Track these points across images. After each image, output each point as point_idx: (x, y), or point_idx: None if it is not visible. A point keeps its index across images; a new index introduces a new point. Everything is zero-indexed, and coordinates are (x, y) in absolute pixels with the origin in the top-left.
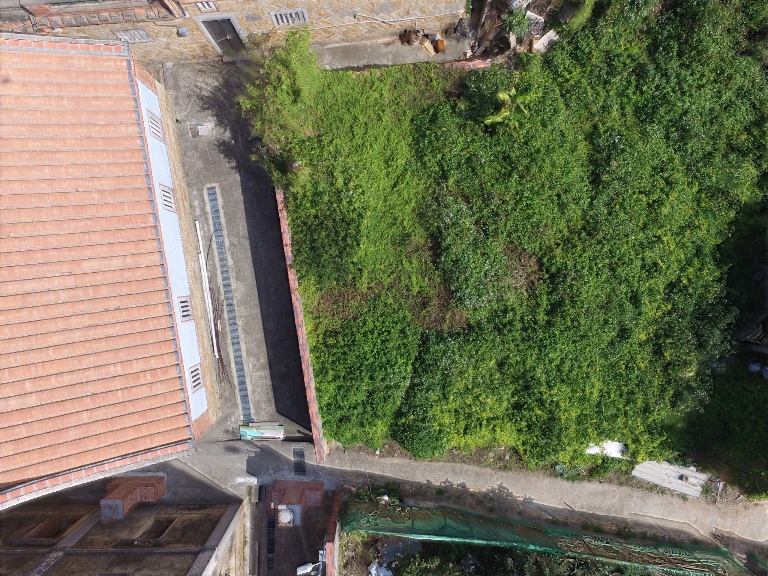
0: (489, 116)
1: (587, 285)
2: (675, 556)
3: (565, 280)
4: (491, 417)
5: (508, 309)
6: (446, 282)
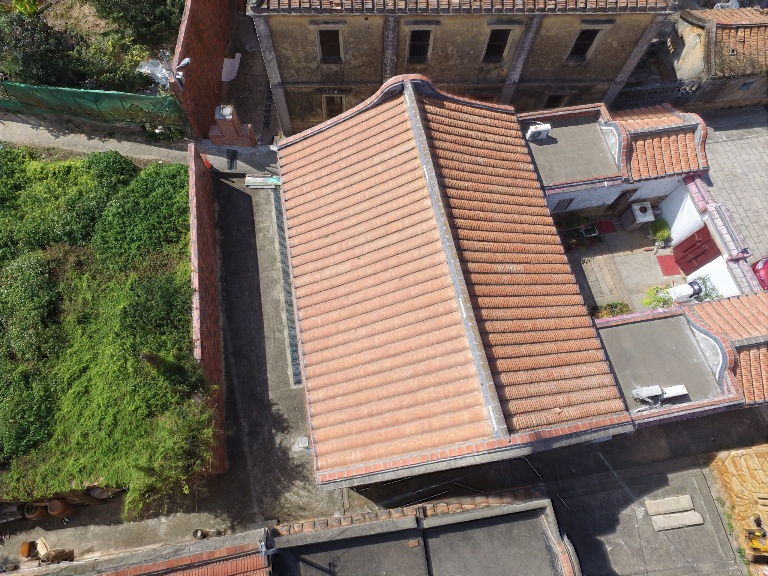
0: None
1: None
2: None
3: None
4: None
5: None
6: (53, 281)
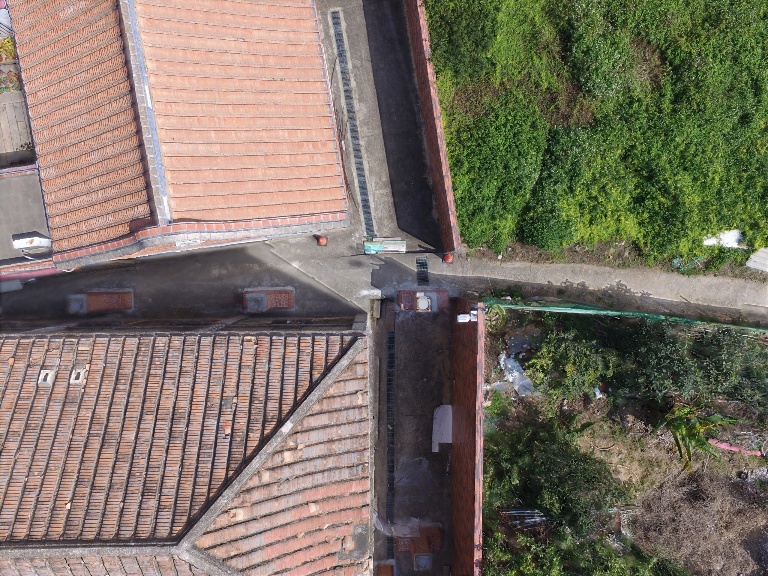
0: None
1: (712, 70)
2: None
3: (690, 67)
4: (615, 209)
5: (634, 100)
6: (575, 76)
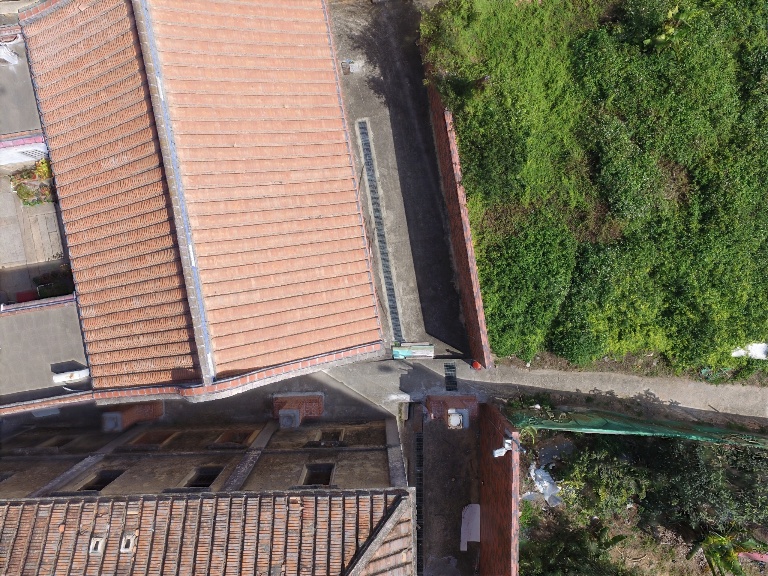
0: (644, 38)
1: (740, 193)
2: None
3: (718, 189)
4: (643, 324)
5: (662, 219)
6: (603, 196)
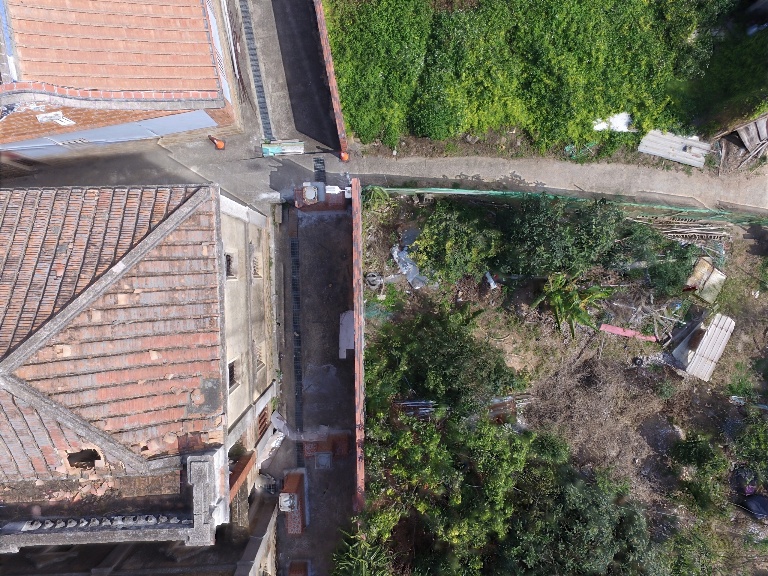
0: None
1: None
2: (681, 223)
3: None
4: (502, 95)
5: None
6: None
